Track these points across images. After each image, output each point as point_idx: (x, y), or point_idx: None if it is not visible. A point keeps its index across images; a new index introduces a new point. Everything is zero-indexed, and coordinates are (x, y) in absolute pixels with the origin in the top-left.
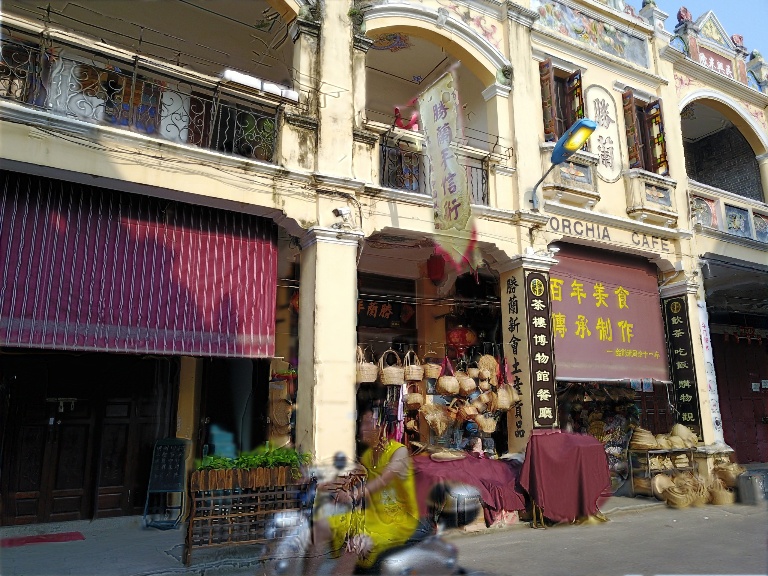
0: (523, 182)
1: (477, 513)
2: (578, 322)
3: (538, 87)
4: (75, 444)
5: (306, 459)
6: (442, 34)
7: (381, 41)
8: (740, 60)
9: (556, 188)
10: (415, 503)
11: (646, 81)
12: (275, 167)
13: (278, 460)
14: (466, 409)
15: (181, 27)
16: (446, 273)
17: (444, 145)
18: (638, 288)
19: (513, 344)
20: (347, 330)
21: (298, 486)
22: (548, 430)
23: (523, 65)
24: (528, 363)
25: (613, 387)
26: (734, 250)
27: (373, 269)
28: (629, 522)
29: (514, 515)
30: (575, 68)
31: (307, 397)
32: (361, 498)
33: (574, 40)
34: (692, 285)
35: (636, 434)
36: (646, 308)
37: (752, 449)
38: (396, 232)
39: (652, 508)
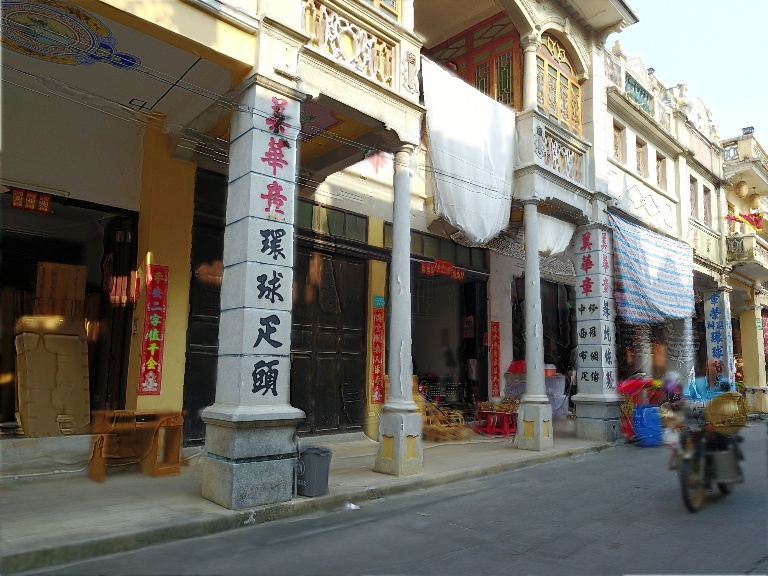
0: None
1: None
2: None
3: None
4: (701, 378)
5: None
6: None
7: None
8: None
9: None
10: None
11: None
12: None
13: None
14: None
15: None
16: None
17: None
18: None
19: None
20: None
21: None
22: None
23: None
24: None
25: None
26: None
27: None
28: None
29: None
30: None
31: None
32: None
33: None
34: None
35: None
36: None
37: None
38: None
39: None
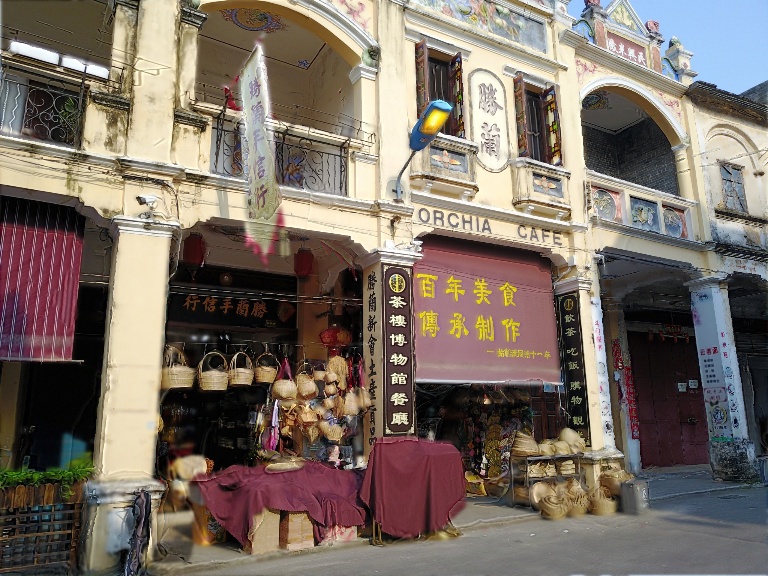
0: (386, 170)
1: (304, 530)
2: (454, 320)
3: (413, 70)
4: None
5: (86, 475)
6: (297, 10)
7: (252, 21)
8: (654, 47)
9: (425, 177)
10: (234, 520)
11: (542, 66)
12: (69, 150)
13: (47, 476)
14: (303, 416)
15: (20, 3)
16: (326, 269)
17: (256, 126)
18: (528, 284)
19: (370, 344)
20: (152, 330)
21: (70, 505)
22: (401, 437)
23: (393, 46)
24: (381, 365)
25: (508, 389)
26: (638, 244)
27: (246, 265)
28: (483, 537)
29: (352, 531)
30: (457, 50)
31: (101, 405)
32: (142, 518)
33: (458, 21)
34: (584, 281)
35: (516, 439)
36: (536, 305)
37: (676, 451)
38: (230, 223)
39: (521, 520)
